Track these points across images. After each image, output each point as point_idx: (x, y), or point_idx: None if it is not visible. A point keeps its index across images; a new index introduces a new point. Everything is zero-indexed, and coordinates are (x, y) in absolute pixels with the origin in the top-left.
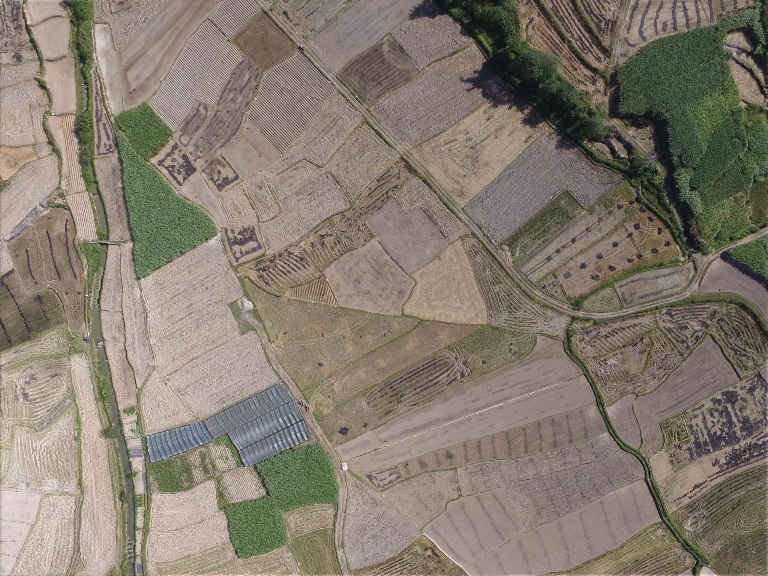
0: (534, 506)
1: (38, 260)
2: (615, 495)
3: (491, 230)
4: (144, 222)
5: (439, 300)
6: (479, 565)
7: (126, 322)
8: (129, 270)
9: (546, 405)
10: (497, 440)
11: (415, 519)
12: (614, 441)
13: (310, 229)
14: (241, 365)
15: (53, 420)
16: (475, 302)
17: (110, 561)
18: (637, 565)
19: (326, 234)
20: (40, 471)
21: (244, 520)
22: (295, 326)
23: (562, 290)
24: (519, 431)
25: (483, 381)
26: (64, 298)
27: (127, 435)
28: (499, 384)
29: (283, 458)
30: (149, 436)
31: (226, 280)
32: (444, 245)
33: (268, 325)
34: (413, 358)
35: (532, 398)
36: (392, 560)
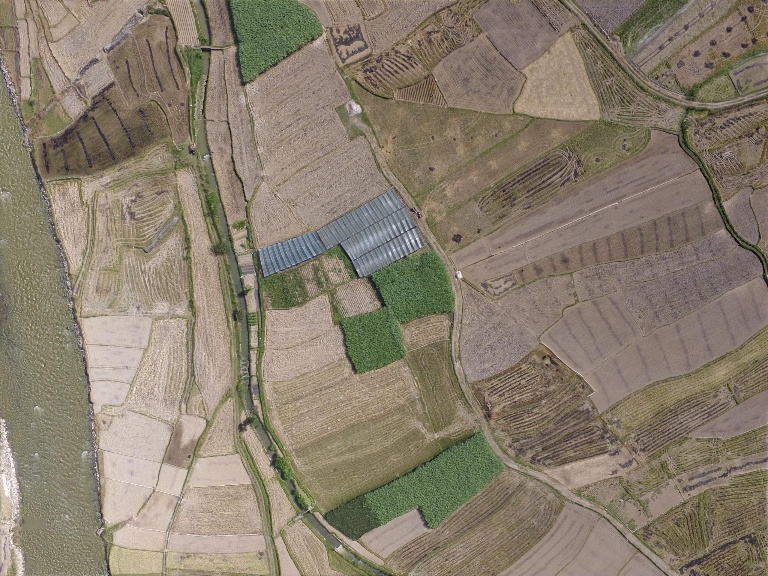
0: (652, 309)
1: (139, 71)
2: (733, 294)
3: (602, 20)
4: (249, 21)
5: (550, 97)
6: (597, 372)
7: (233, 131)
8: (233, 76)
9: (661, 203)
10: (613, 242)
11: (532, 327)
12: (731, 237)
13: (417, 26)
14: (351, 173)
15: (161, 240)
16: (587, 97)
17: (225, 383)
18: (757, 366)
19: (433, 31)
20: (150, 294)
21: (361, 332)
22: (404, 129)
23: (676, 80)
24: (635, 231)
25: (597, 180)
26: (167, 110)
27: (237, 251)
28: (613, 183)
29: (398, 266)
30: (261, 249)
31: (333, 83)
32: (554, 38)
33: (377, 129)
34: (525, 159)
35: (647, 196)
36: (510, 370)
